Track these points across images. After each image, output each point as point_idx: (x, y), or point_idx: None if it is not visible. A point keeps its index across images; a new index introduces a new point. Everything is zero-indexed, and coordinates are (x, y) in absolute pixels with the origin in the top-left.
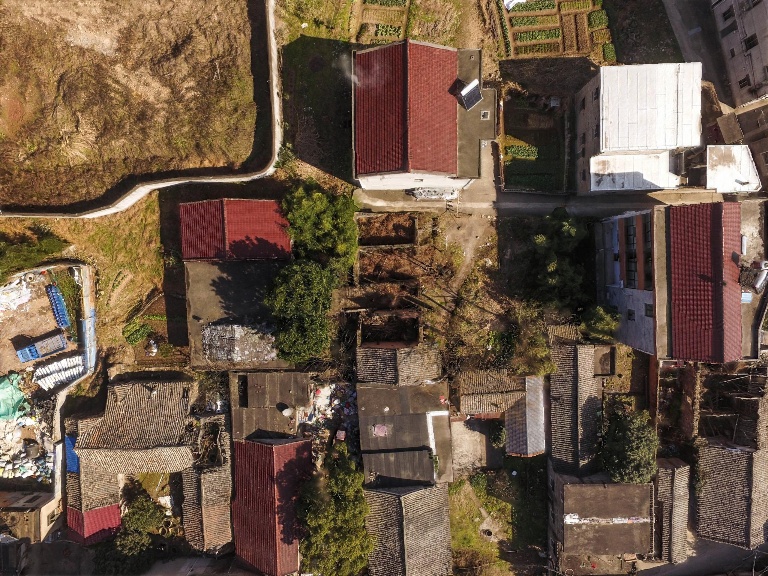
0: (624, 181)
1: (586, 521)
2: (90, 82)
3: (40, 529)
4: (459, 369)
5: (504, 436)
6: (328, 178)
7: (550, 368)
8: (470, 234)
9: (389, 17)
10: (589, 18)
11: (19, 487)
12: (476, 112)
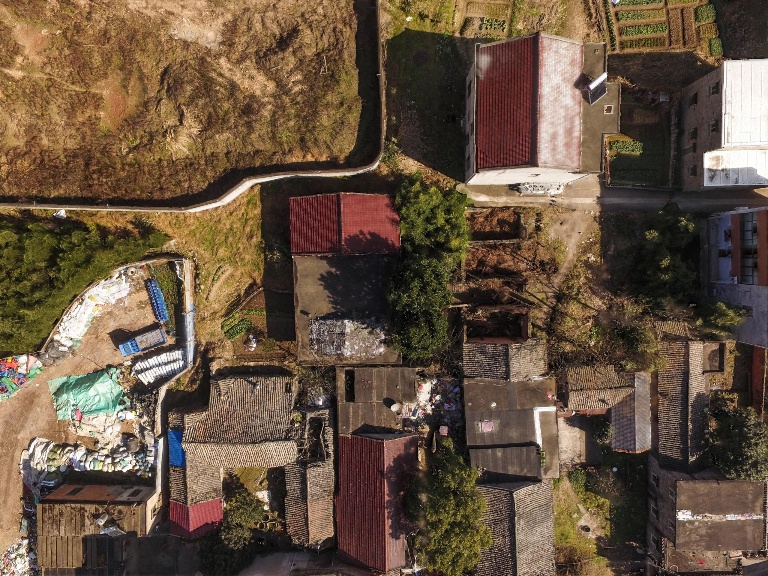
0: (738, 176)
1: (699, 517)
2: (195, 75)
3: (146, 523)
4: (565, 365)
5: (610, 432)
6: (430, 173)
7: (661, 364)
8: (573, 229)
9: (494, 11)
10: (696, 12)
11: (118, 481)
12: (599, 106)
